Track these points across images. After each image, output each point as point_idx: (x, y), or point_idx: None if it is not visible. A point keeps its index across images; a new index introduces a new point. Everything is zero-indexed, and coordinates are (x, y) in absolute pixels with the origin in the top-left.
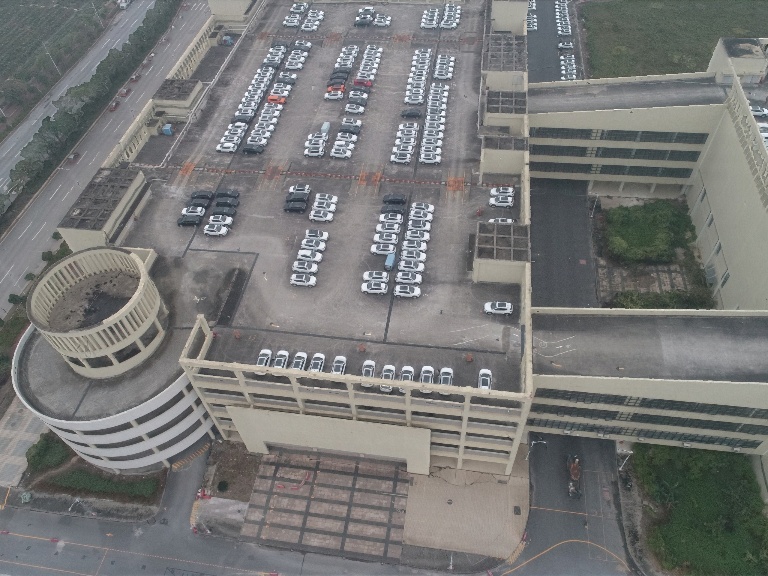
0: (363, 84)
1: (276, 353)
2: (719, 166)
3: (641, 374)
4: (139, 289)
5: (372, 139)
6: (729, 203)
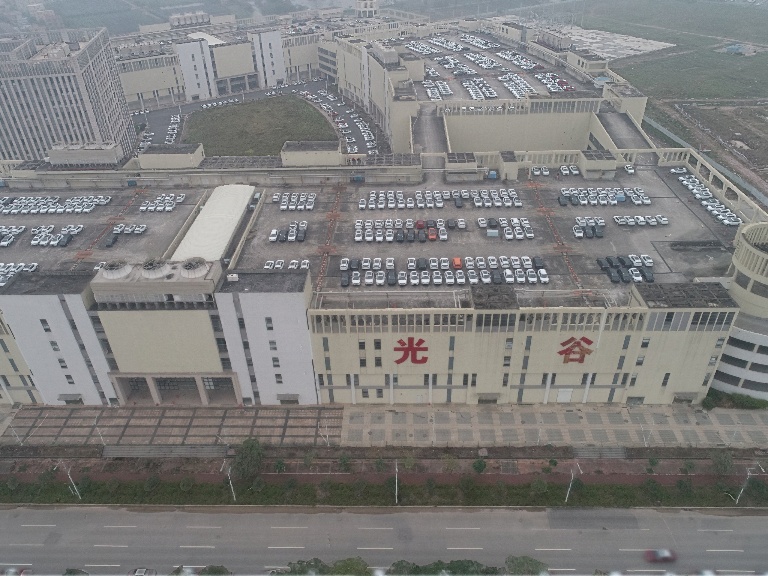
0: (424, 222)
1: (720, 222)
2: (464, 138)
3: (643, 142)
4: (766, 223)
5: (496, 216)
6: (493, 139)
